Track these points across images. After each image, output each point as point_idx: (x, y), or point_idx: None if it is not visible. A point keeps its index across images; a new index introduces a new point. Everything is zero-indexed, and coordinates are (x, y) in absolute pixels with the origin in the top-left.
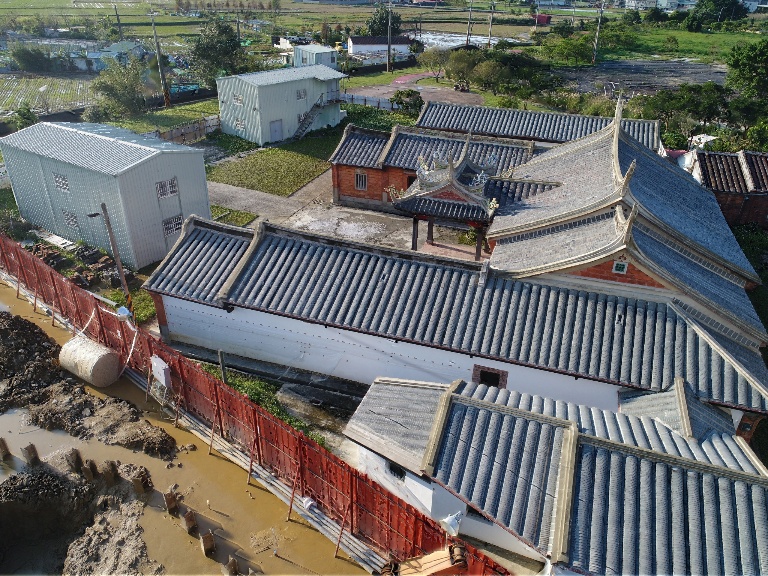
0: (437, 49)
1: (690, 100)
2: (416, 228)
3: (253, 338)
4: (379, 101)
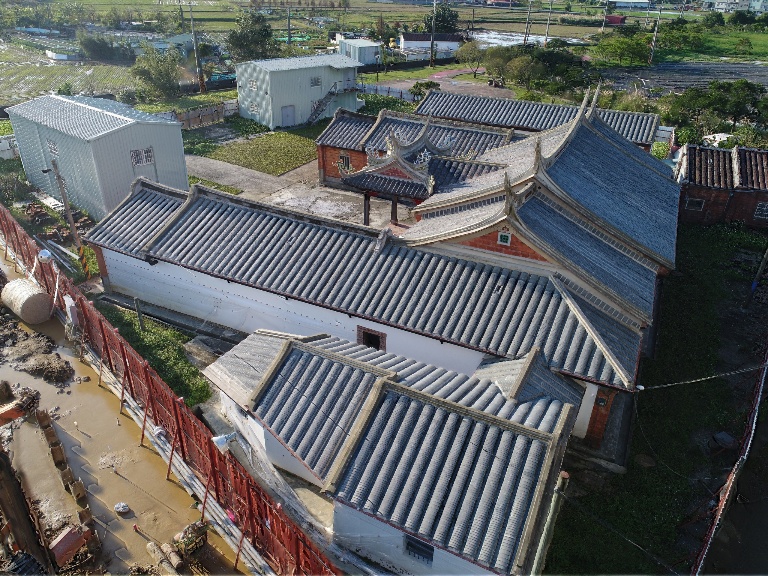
0: (476, 44)
1: (717, 98)
2: (367, 204)
3: (175, 291)
4: (402, 92)
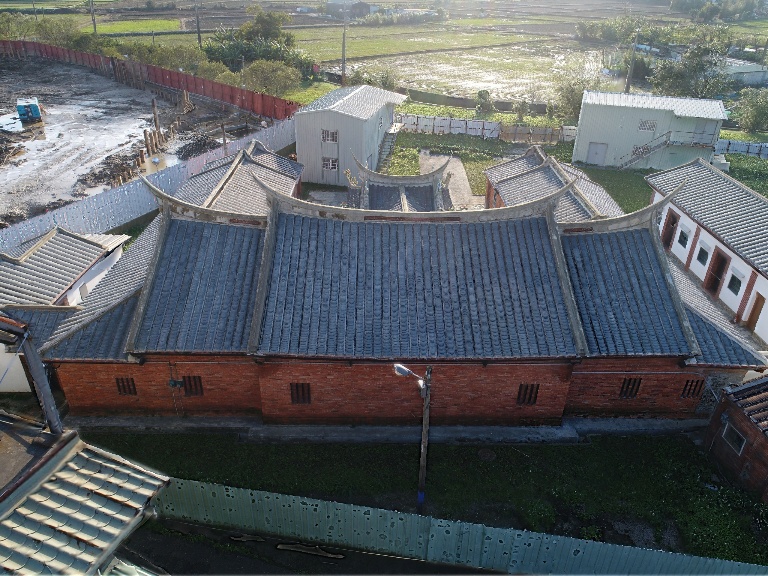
0: None
1: None
2: None
3: None
4: None
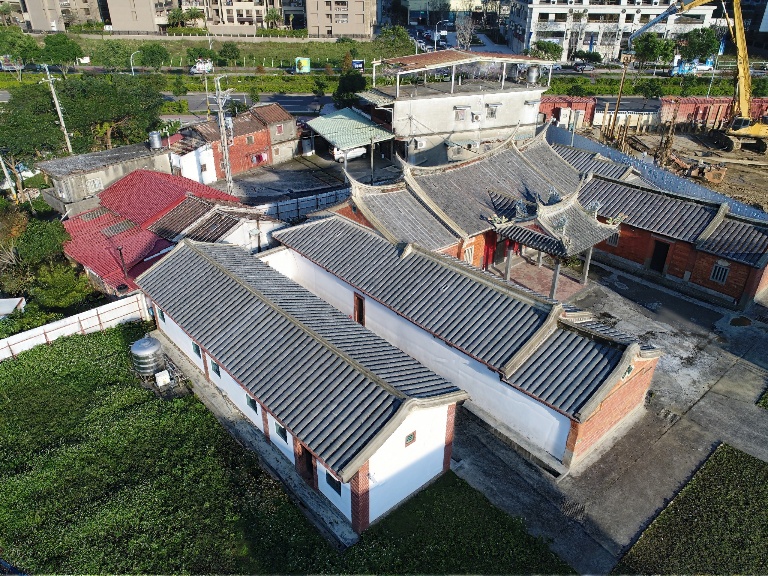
0: None
1: None
2: None
3: None
4: None
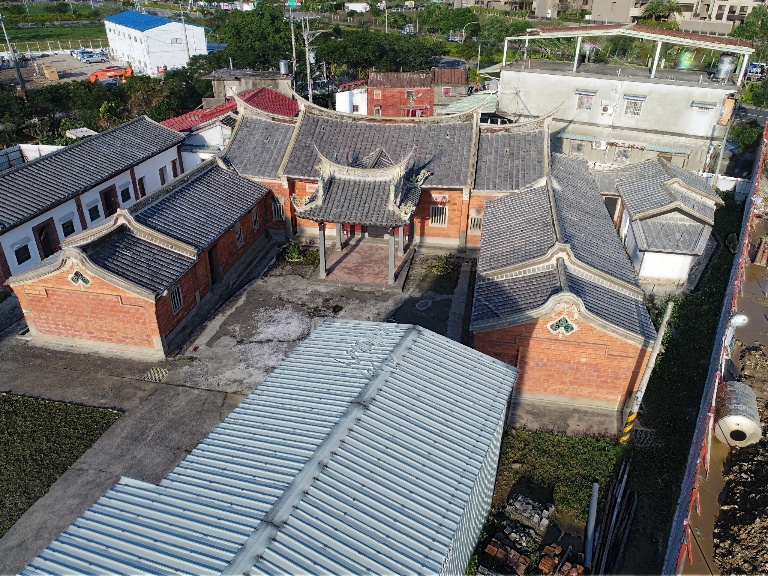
0: None
1: None
2: None
3: None
4: None
